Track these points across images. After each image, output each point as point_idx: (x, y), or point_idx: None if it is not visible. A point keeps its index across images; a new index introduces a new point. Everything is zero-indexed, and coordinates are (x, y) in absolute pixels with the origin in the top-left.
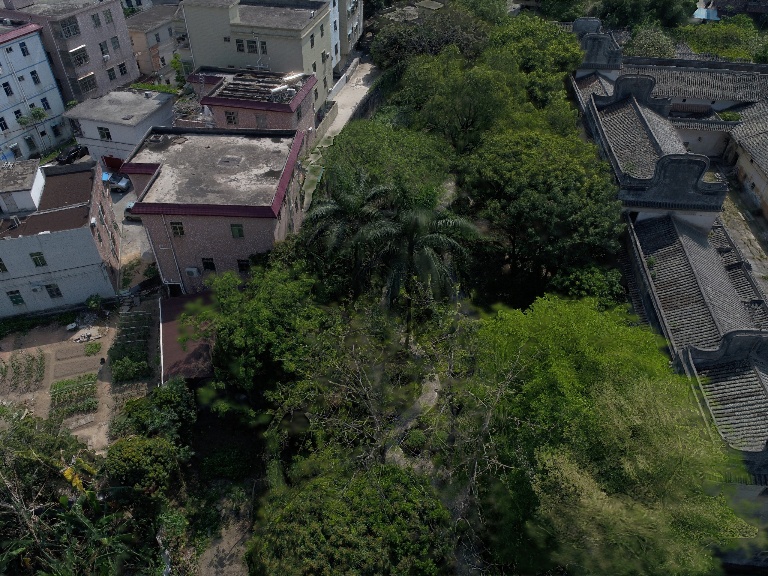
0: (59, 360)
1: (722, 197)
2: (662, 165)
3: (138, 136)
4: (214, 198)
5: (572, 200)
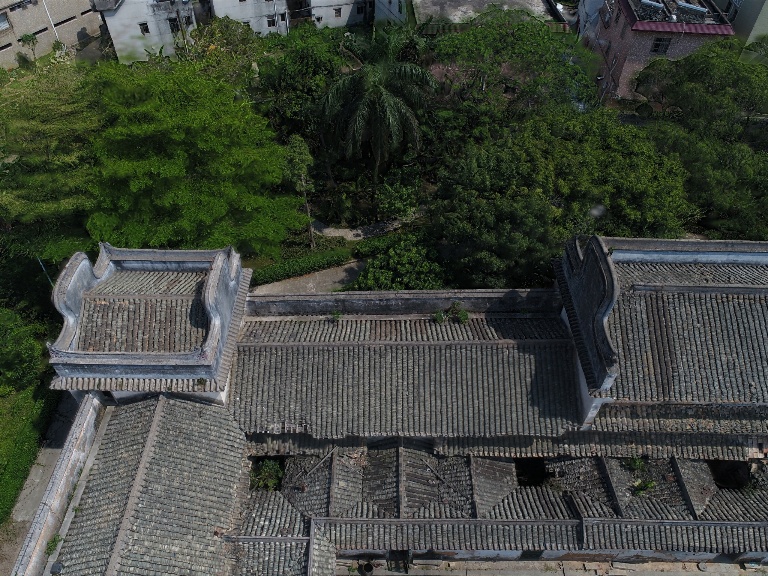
0: (352, 66)
1: (603, 374)
2: (588, 247)
3: (592, 5)
4: (432, 9)
5: (476, 173)
